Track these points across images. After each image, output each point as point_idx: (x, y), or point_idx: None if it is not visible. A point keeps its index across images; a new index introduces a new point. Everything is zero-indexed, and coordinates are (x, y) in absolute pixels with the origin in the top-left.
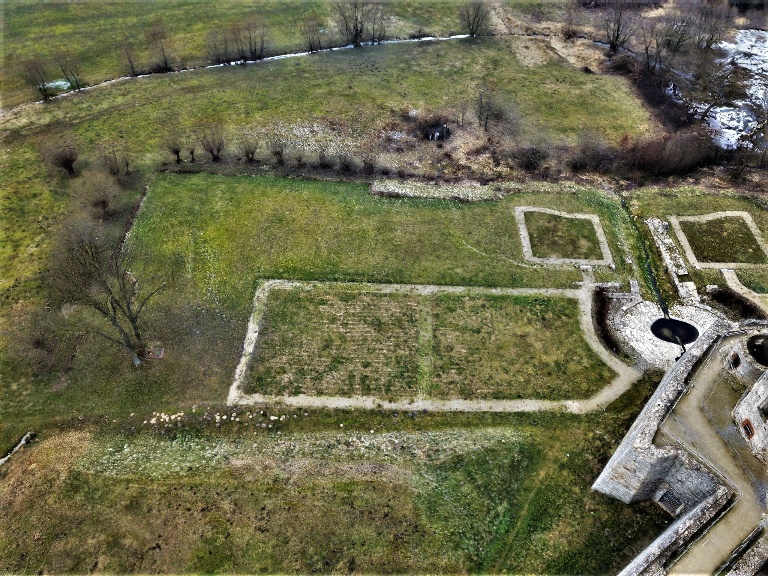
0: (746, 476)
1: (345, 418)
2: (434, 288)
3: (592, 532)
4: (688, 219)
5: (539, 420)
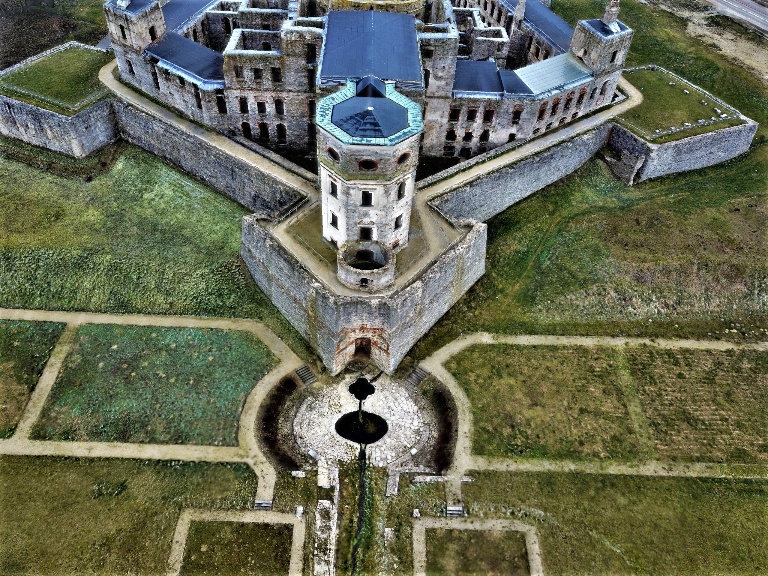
0: None
1: (677, 331)
2: (645, 470)
3: (491, 244)
4: None
5: (518, 326)
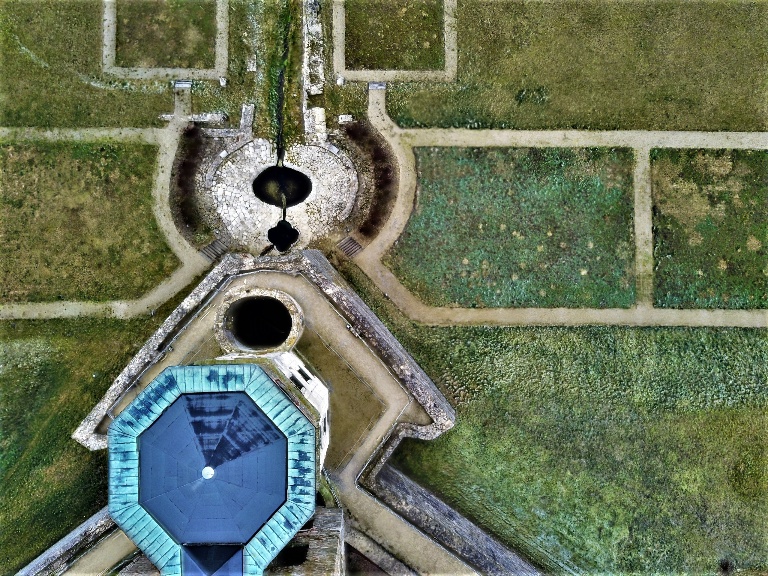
0: None
1: None
2: None
3: (84, 471)
4: None
5: (74, 330)
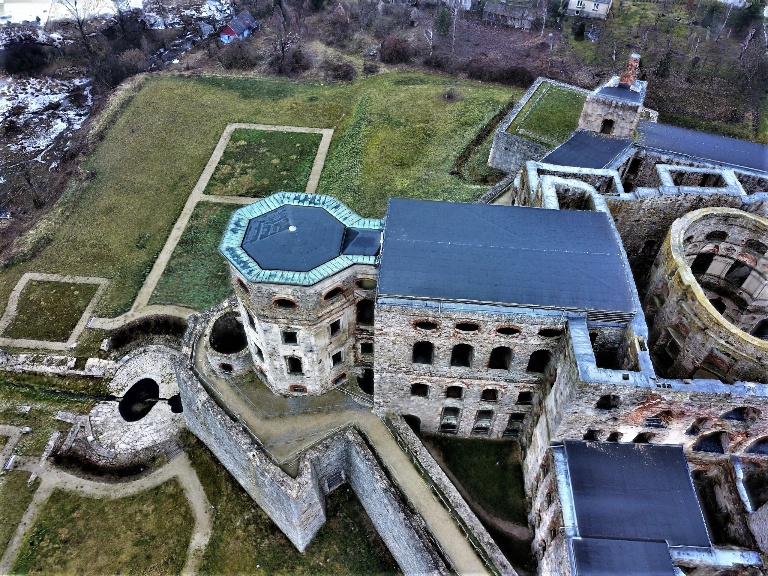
0: (338, 410)
1: None
2: None
3: (349, 567)
4: (2, 327)
5: None
